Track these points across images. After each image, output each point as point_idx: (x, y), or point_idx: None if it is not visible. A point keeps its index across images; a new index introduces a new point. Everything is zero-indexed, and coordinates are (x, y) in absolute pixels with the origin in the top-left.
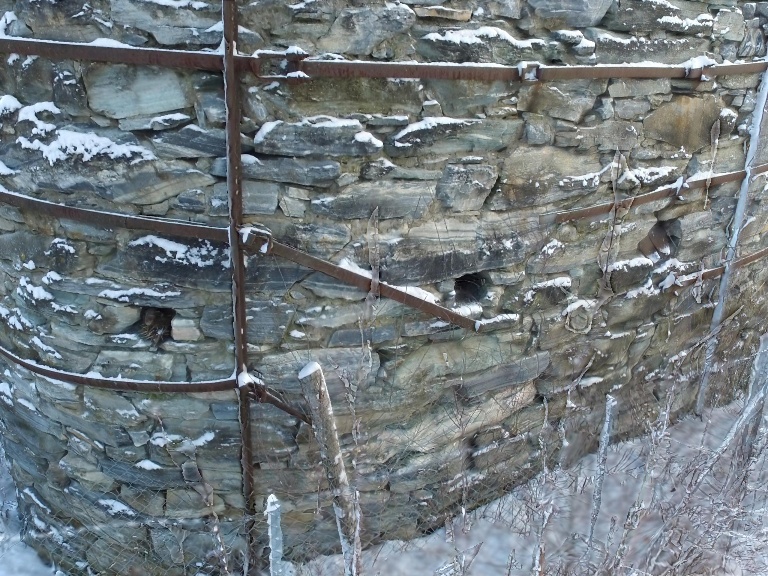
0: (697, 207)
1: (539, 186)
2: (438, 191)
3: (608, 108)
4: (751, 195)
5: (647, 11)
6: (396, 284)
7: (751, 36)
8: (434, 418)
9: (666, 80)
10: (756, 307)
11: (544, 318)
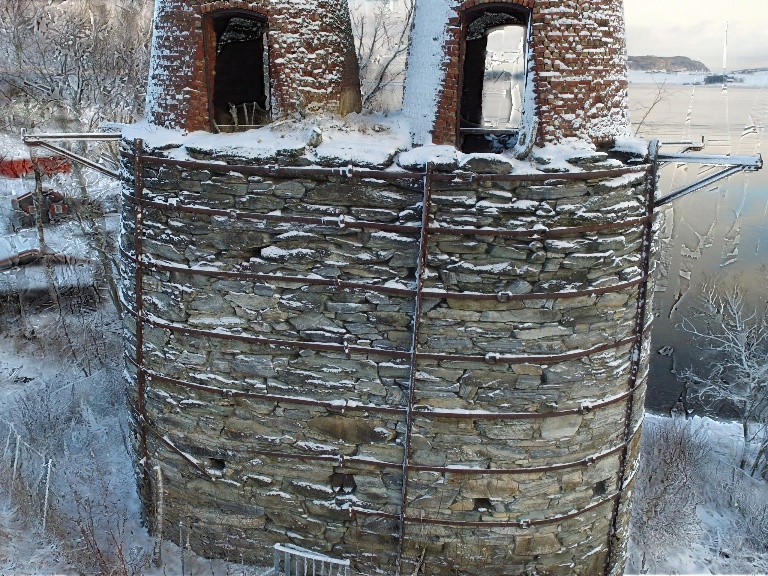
0: (367, 473)
1: (244, 435)
2: (198, 424)
3: (279, 412)
4: (423, 481)
5: (297, 377)
6: (183, 451)
7: (395, 394)
8: (209, 510)
9: (320, 406)
10: (469, 560)
11: (257, 491)
